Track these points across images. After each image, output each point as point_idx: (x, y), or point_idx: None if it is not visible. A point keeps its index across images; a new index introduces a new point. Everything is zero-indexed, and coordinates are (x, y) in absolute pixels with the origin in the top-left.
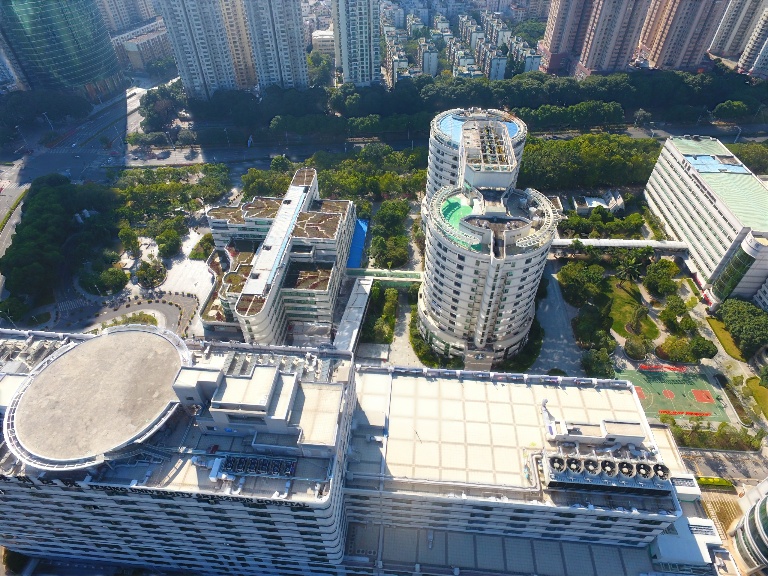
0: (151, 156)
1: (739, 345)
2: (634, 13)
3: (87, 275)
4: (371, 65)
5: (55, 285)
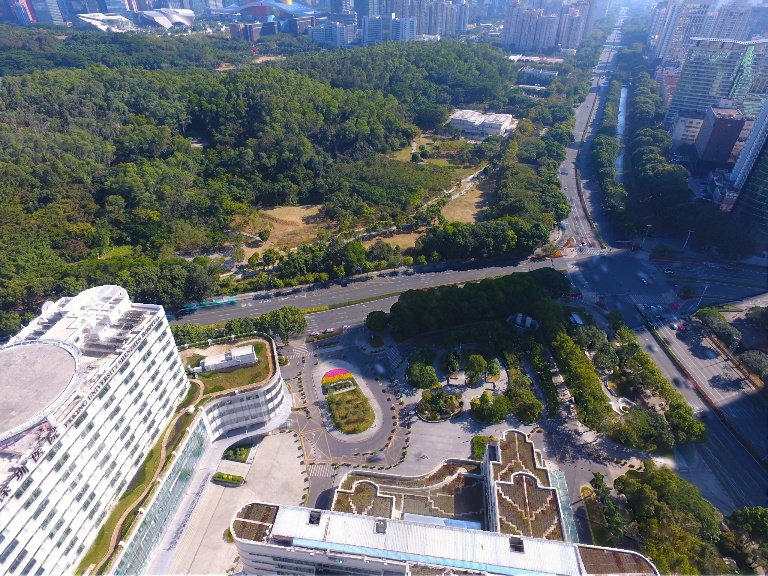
0: (692, 340)
1: None
2: None
3: (435, 353)
4: None
5: (409, 335)
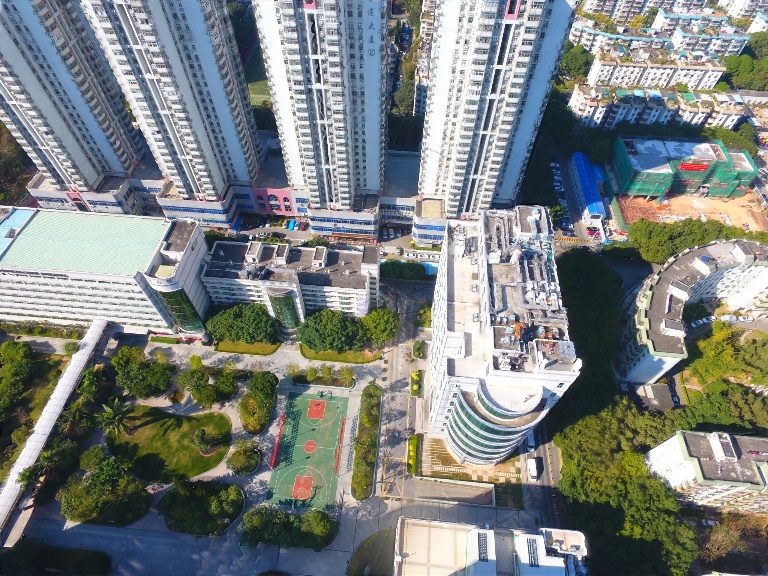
0: None
1: (265, 343)
2: None
3: None
4: None
5: None
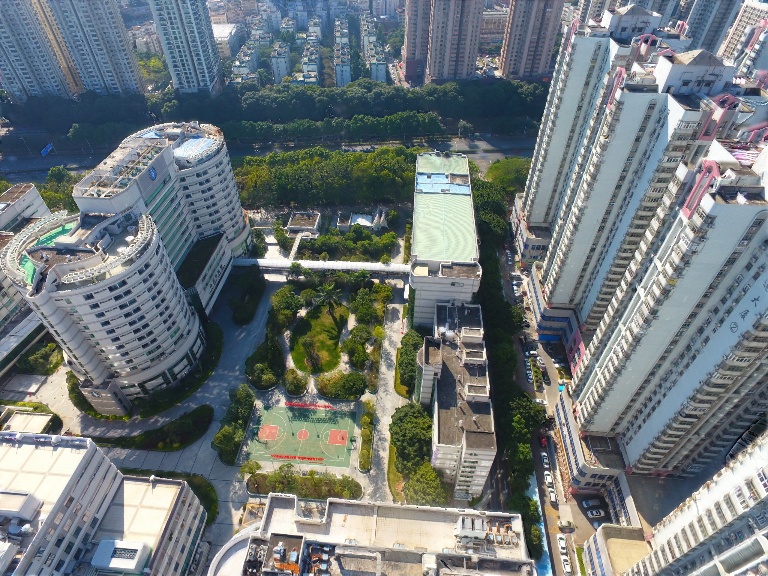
0: None
1: None
2: (463, 20)
3: None
4: (196, 71)
5: None
